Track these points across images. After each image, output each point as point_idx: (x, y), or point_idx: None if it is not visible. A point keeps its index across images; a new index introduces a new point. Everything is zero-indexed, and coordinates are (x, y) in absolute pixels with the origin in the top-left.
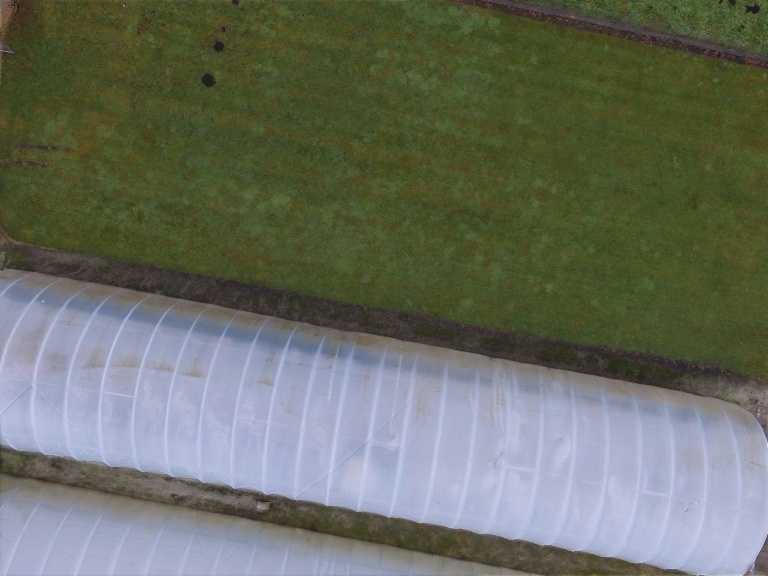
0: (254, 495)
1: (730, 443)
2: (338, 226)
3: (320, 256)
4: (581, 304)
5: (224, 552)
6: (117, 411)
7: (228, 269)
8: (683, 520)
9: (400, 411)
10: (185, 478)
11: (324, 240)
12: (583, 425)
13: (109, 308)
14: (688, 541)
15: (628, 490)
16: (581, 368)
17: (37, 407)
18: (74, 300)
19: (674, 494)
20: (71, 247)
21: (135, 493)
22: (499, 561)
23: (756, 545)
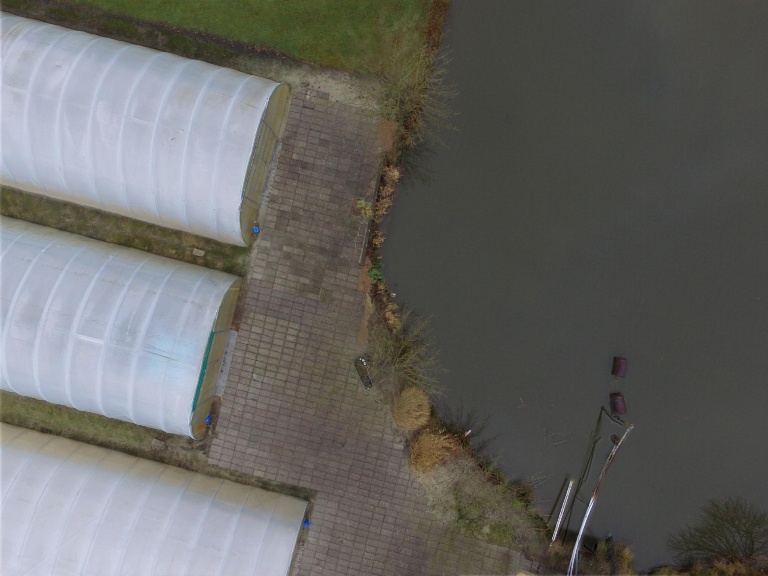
0: None
1: (234, 89)
2: None
3: None
4: None
5: None
6: None
7: None
8: (169, 149)
9: None
10: None
11: None
12: (88, 58)
13: None
14: (176, 172)
15: (116, 115)
16: (140, 42)
17: None
18: None
19: (160, 122)
20: None
21: None
22: (45, 221)
23: (239, 178)
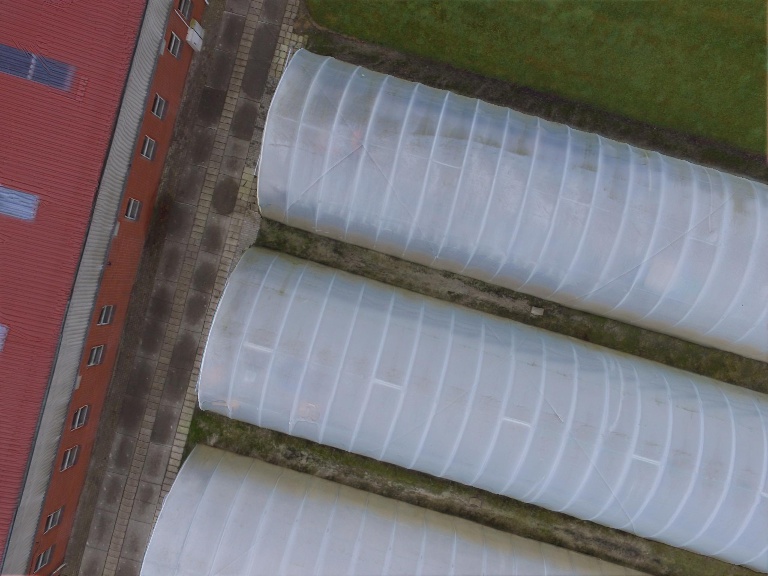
0: (529, 300)
1: None
2: (636, 44)
3: (616, 72)
4: None
5: (516, 339)
6: (443, 180)
7: (524, 76)
8: None
9: (718, 209)
10: (464, 276)
11: (621, 57)
12: None
13: (425, 89)
14: None
15: None
16: None
17: (364, 168)
18: (391, 78)
19: None
20: (372, 38)
21: (413, 286)
22: (764, 388)
23: None
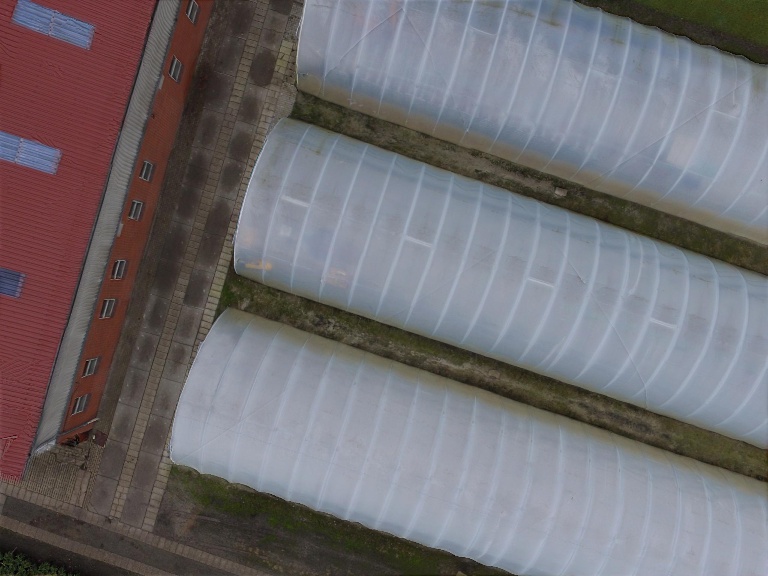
0: (553, 181)
1: None
2: None
3: None
4: None
5: (542, 210)
6: (479, 45)
7: None
8: None
9: (742, 85)
10: (491, 155)
11: None
12: None
13: None
14: None
15: None
16: None
17: (403, 32)
18: None
19: None
20: None
21: (441, 163)
22: None
23: None
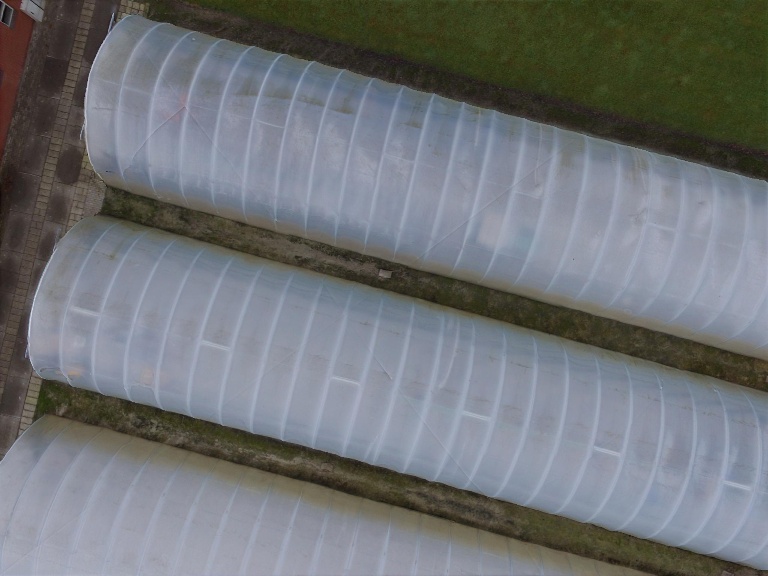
0: (377, 263)
1: None
2: (479, 5)
3: (459, 33)
4: (714, 100)
5: (353, 300)
6: (267, 139)
7: (367, 39)
8: None
9: (545, 163)
10: (310, 240)
11: (464, 18)
12: (723, 194)
13: (257, 52)
14: None
15: (766, 256)
16: (709, 163)
17: (188, 130)
18: (223, 42)
19: None
20: (214, 5)
21: (259, 252)
22: (615, 346)
23: None
